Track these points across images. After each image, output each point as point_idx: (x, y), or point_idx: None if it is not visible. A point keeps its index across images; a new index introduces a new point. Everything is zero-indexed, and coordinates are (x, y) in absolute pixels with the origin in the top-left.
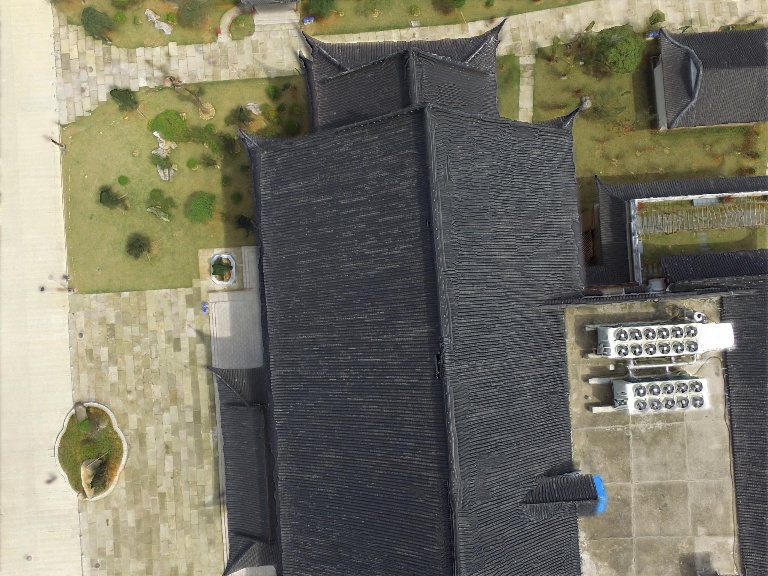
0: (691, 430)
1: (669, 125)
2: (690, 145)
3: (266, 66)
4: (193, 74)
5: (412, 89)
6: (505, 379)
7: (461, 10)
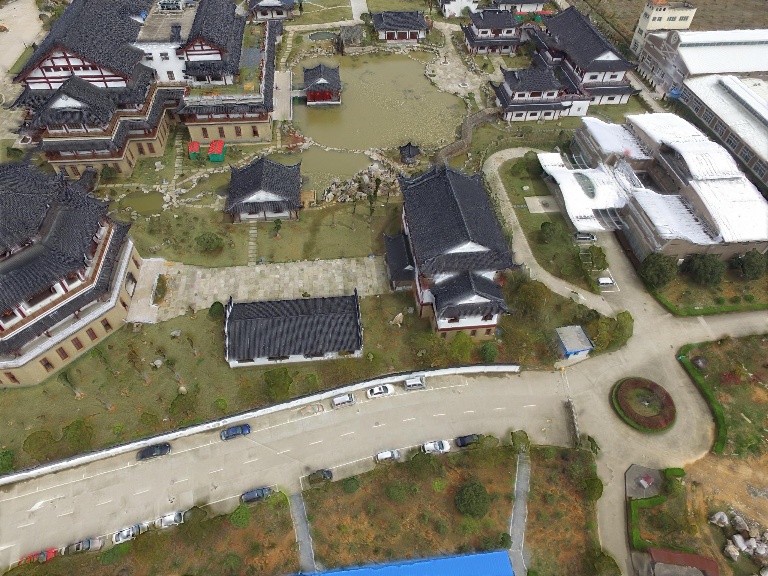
0: (183, 19)
1: None
2: None
3: None
4: None
5: None
6: None
7: None
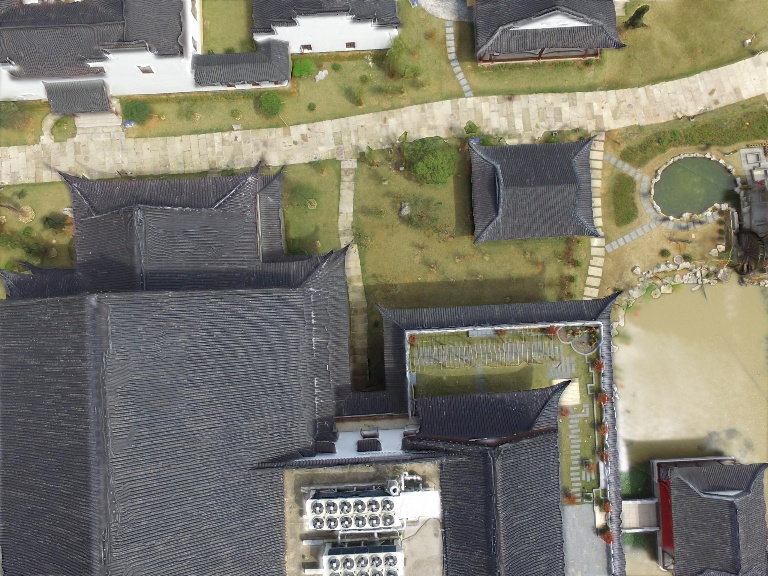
0: None
1: (474, 240)
2: (510, 252)
3: (88, 168)
4: (16, 176)
5: (138, 246)
6: (199, 551)
7: (282, 115)
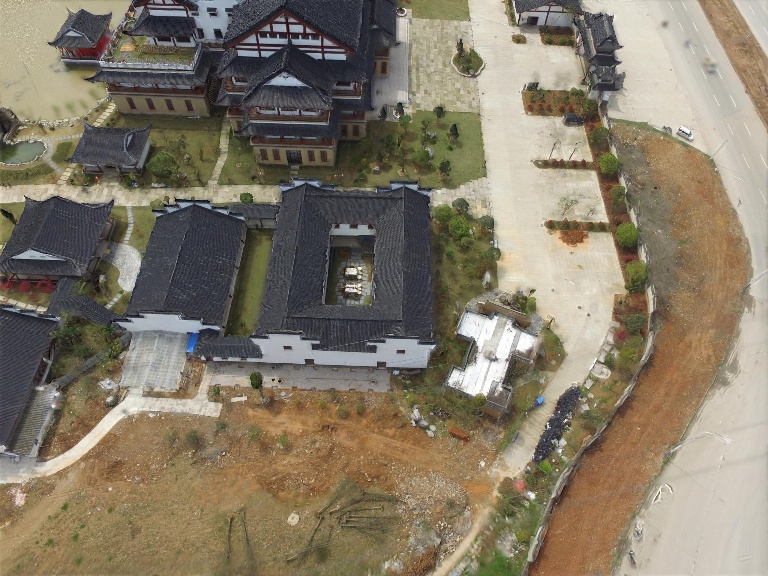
0: None
1: None
2: None
3: None
4: None
5: None
6: None
7: None
